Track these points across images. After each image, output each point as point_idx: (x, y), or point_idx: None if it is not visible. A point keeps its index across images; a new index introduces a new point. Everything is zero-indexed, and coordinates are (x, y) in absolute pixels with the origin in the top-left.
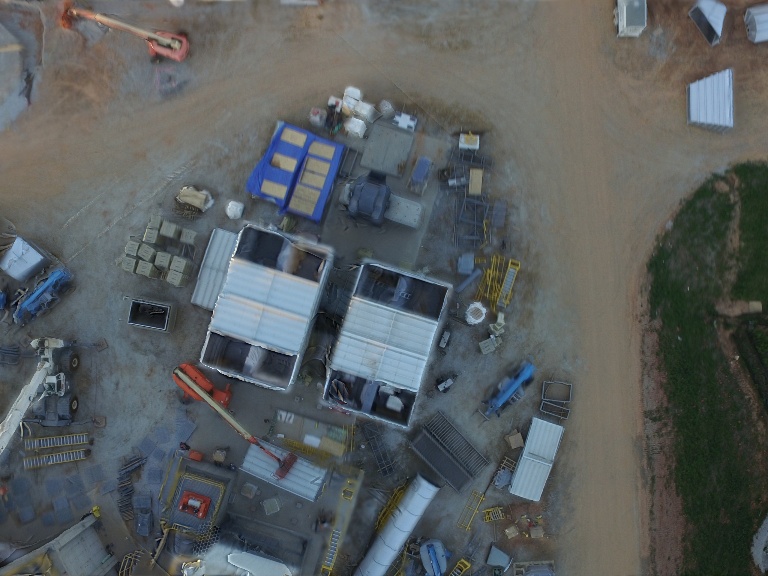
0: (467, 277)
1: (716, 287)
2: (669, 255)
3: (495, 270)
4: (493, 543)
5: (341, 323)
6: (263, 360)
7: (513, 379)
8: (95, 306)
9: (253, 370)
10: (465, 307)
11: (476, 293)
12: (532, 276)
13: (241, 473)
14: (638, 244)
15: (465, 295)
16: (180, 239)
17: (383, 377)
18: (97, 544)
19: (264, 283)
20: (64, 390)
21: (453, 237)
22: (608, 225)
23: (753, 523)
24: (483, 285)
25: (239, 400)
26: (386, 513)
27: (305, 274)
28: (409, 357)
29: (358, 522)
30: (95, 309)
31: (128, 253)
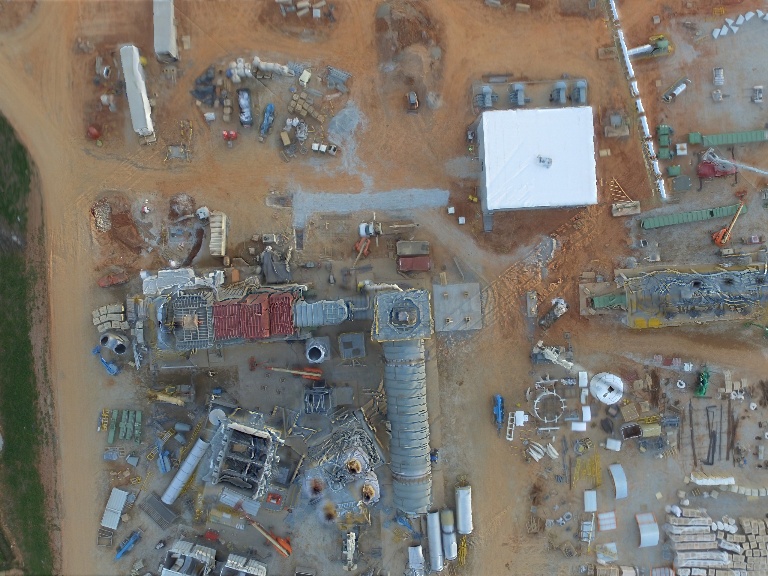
0: None
1: None
2: None
3: None
4: (137, 466)
5: None
6: (238, 575)
7: (126, 551)
8: None
9: None
10: None
11: None
12: None
13: None
14: None
15: None
16: None
17: (179, 575)
18: None
19: None
20: None
21: None
22: None
23: (3, 456)
24: None
25: None
26: None
27: None
28: None
29: None
30: (336, 575)
31: None
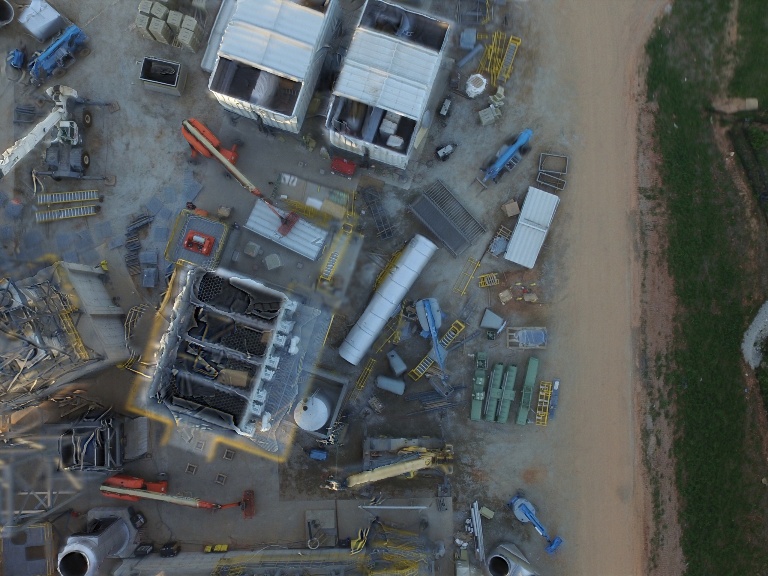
0: (469, 52)
1: (713, 82)
2: (667, 41)
3: (496, 46)
4: (487, 308)
5: (345, 54)
6: (269, 94)
7: None
8: (108, 70)
9: (259, 102)
10: (466, 77)
11: (477, 68)
12: (532, 53)
13: (245, 232)
14: (637, 26)
15: (466, 70)
16: (192, 2)
17: (384, 104)
18: (104, 294)
19: (272, 12)
20: (77, 141)
21: (456, 14)
22: (608, 6)
23: (744, 320)
24: (484, 60)
25: (245, 162)
26: (384, 273)
27: (311, 7)
28: (410, 86)
29: (357, 285)
30: (108, 73)
31: (142, 10)
